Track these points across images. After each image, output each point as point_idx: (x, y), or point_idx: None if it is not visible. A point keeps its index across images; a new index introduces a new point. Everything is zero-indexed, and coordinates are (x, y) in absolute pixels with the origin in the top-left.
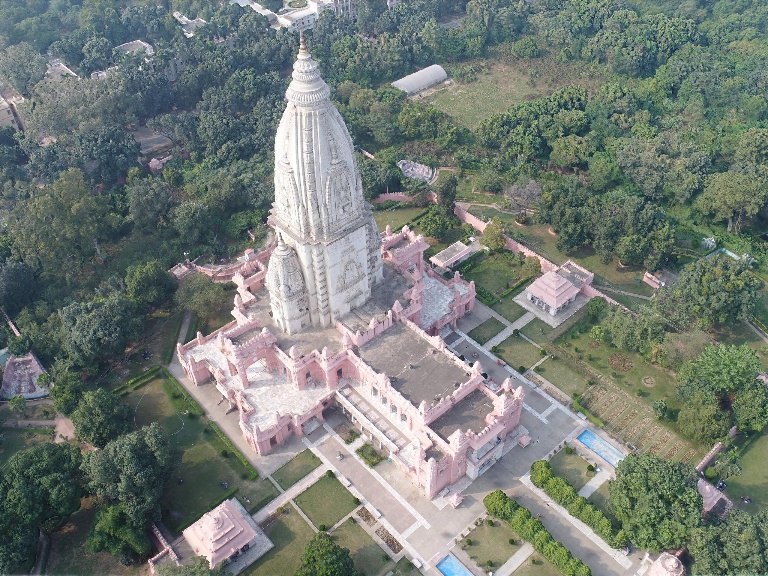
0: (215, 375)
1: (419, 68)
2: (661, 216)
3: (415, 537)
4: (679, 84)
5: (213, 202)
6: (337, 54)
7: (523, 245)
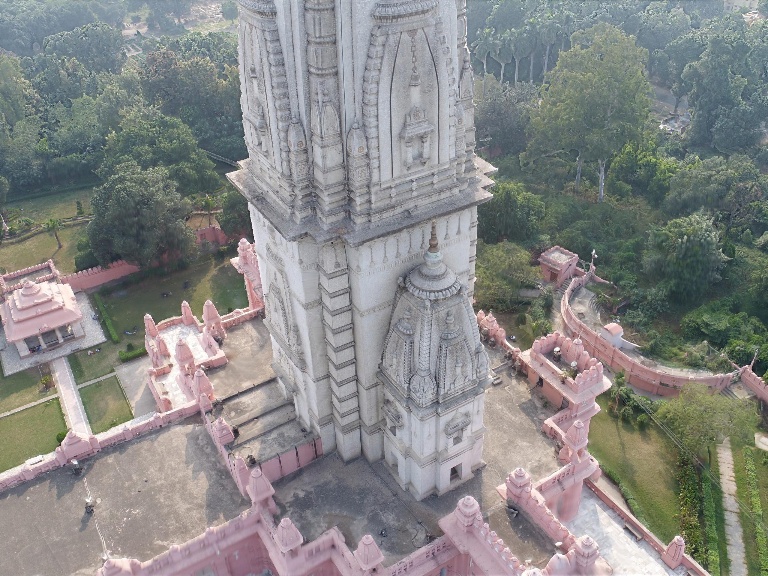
0: None
1: None
2: None
3: None
4: None
5: (758, 271)
6: None
7: None
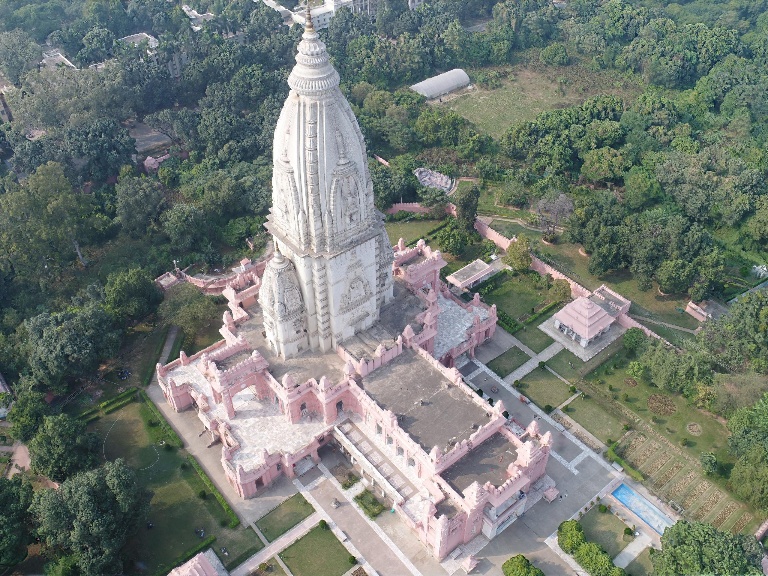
0: (197, 402)
1: (440, 72)
2: (708, 239)
3: None
4: (722, 97)
5: (209, 206)
6: (353, 54)
7: (550, 266)
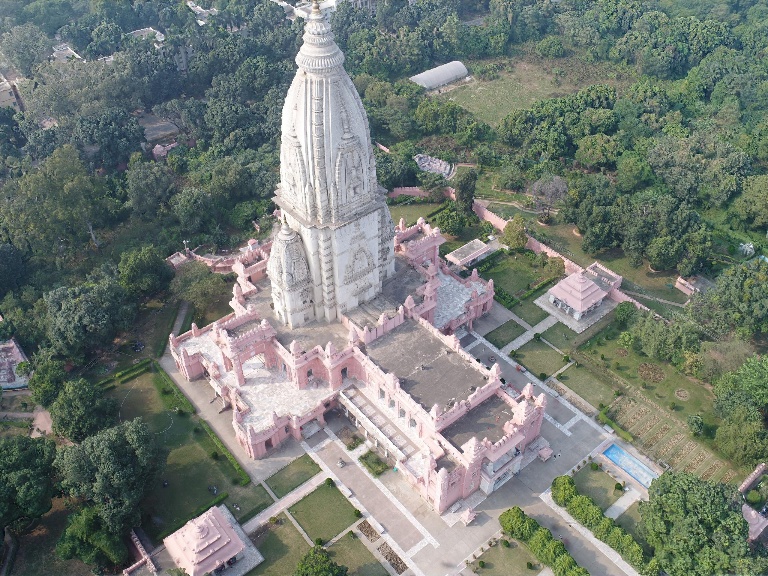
0: (209, 370)
1: (439, 64)
2: (696, 218)
3: (421, 556)
4: (712, 86)
5: (217, 190)
6: (354, 47)
7: (545, 245)
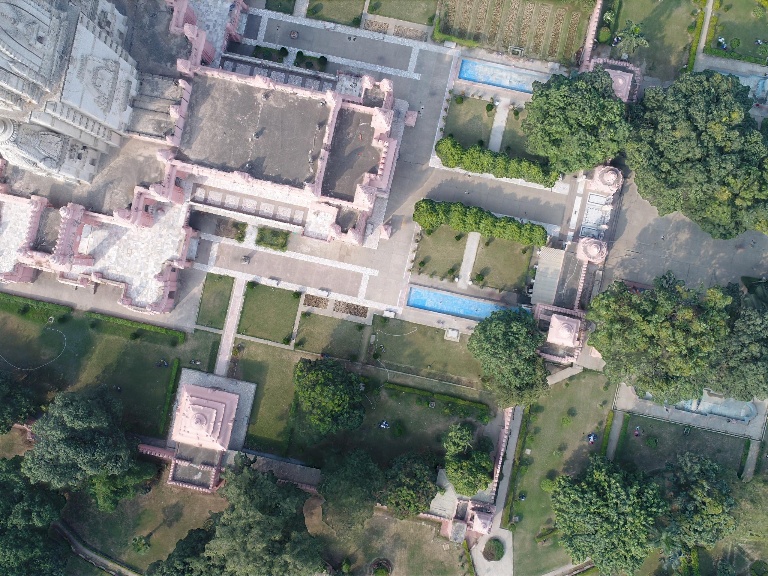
0: None
1: None
2: None
3: (372, 291)
4: None
5: None
6: None
7: None
